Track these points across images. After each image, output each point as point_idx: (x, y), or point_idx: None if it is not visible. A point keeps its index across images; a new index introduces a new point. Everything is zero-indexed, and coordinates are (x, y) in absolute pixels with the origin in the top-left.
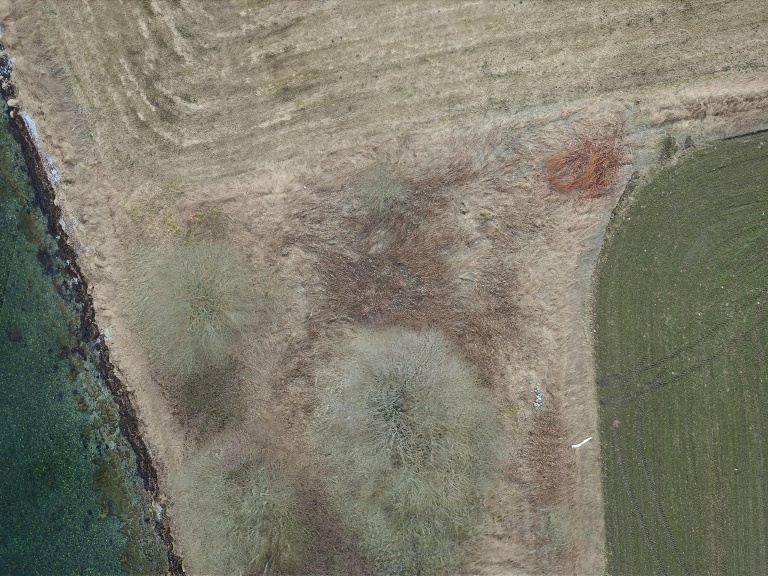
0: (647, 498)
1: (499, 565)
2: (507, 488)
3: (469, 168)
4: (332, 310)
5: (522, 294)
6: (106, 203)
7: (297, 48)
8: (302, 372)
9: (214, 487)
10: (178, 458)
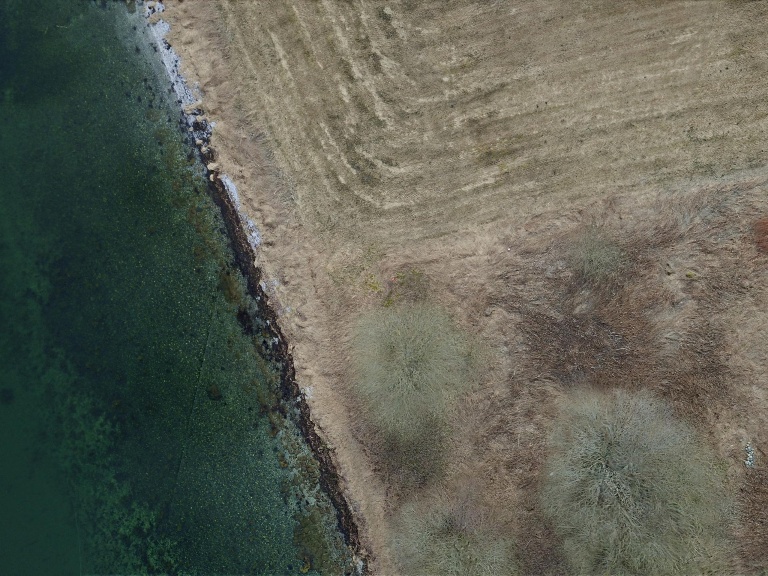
0: None
1: None
2: (718, 544)
3: (675, 230)
4: (535, 369)
5: (731, 354)
6: (307, 265)
7: (501, 113)
8: (504, 429)
9: (417, 542)
10: (379, 514)
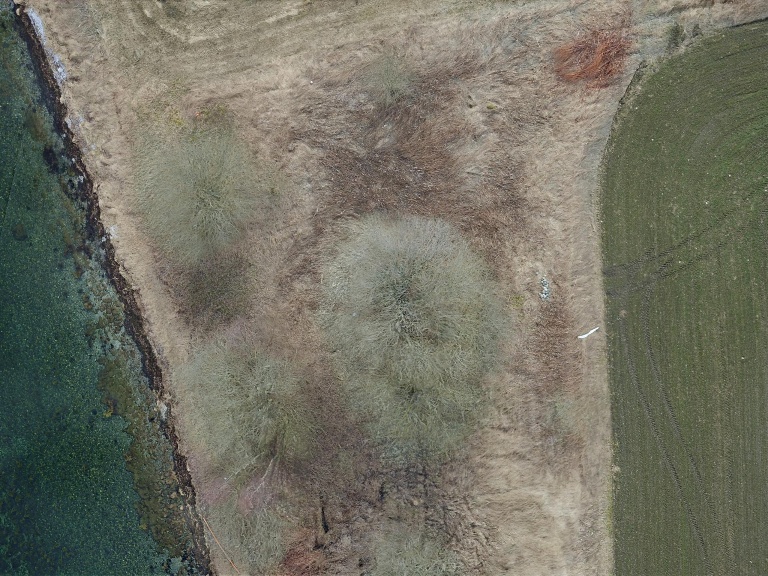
0: (653, 388)
1: (505, 458)
2: (513, 380)
3: (476, 61)
4: (338, 206)
5: (529, 186)
6: (112, 100)
7: None
8: (308, 269)
9: (219, 385)
10: (183, 357)
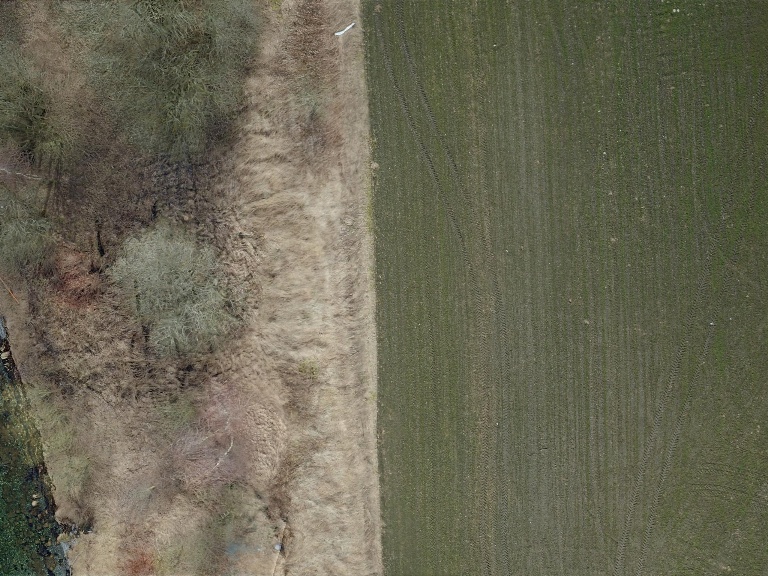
0: (409, 82)
1: (267, 162)
2: (273, 82)
3: None
4: None
5: None
6: None
7: None
8: None
9: None
10: None
